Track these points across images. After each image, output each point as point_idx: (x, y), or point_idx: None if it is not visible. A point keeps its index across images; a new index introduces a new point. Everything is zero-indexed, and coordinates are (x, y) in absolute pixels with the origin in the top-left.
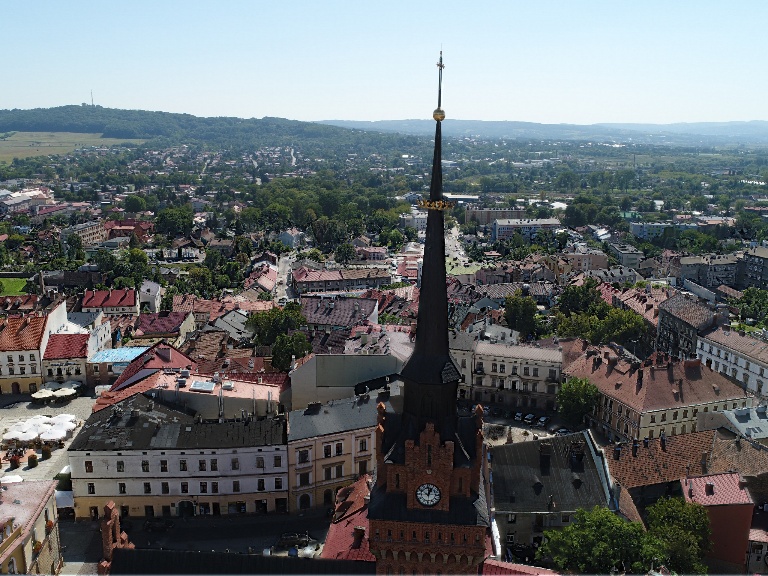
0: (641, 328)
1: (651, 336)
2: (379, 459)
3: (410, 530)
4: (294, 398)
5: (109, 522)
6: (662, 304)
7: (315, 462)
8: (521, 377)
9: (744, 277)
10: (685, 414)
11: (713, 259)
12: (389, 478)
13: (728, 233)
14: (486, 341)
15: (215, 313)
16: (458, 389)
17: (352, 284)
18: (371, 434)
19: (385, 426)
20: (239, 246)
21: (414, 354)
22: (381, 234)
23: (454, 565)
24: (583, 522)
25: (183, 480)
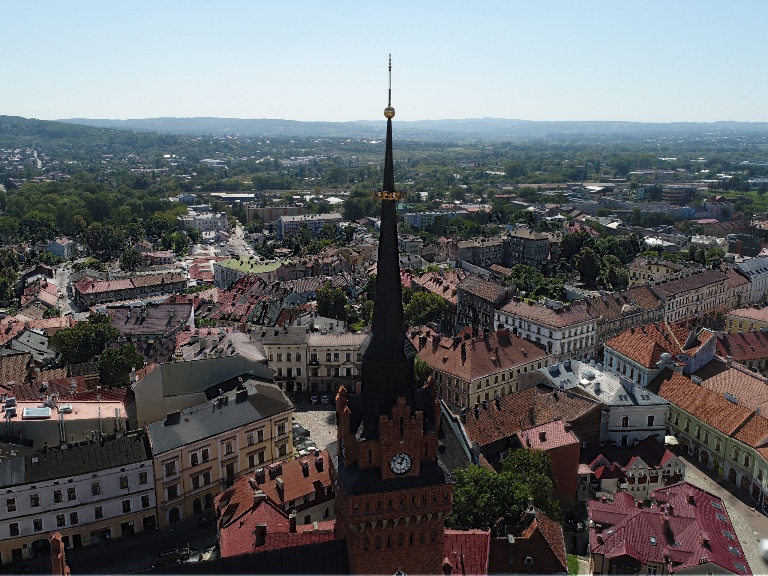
0: (443, 308)
1: (452, 314)
2: (347, 439)
3: (387, 499)
4: (139, 412)
5: (59, 555)
6: (459, 284)
7: (182, 473)
8: (354, 363)
9: (509, 256)
10: (503, 377)
11: (484, 242)
12: (362, 455)
13: (487, 218)
14: (316, 333)
15: (1, 336)
16: (294, 383)
17: (145, 292)
18: (236, 435)
19: (349, 408)
20: (1, 260)
21: (374, 336)
22: (164, 238)
23: (425, 524)
24: (462, 480)
25: (35, 517)
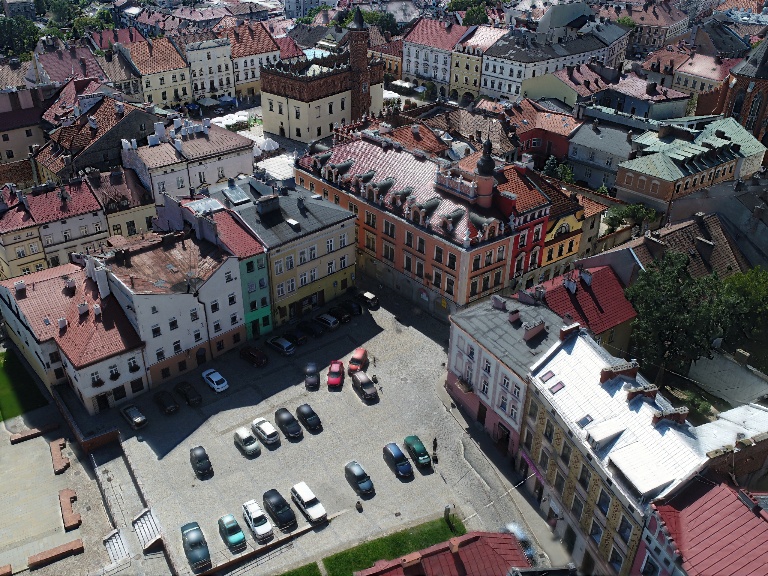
0: None
1: None
2: None
3: None
4: None
5: None
6: None
7: None
8: None
9: None
10: None
11: None
12: None
13: None
14: None
15: None
16: None
17: None
18: None
19: None
20: (50, 0)
21: None
22: None
23: None
24: None
25: None
